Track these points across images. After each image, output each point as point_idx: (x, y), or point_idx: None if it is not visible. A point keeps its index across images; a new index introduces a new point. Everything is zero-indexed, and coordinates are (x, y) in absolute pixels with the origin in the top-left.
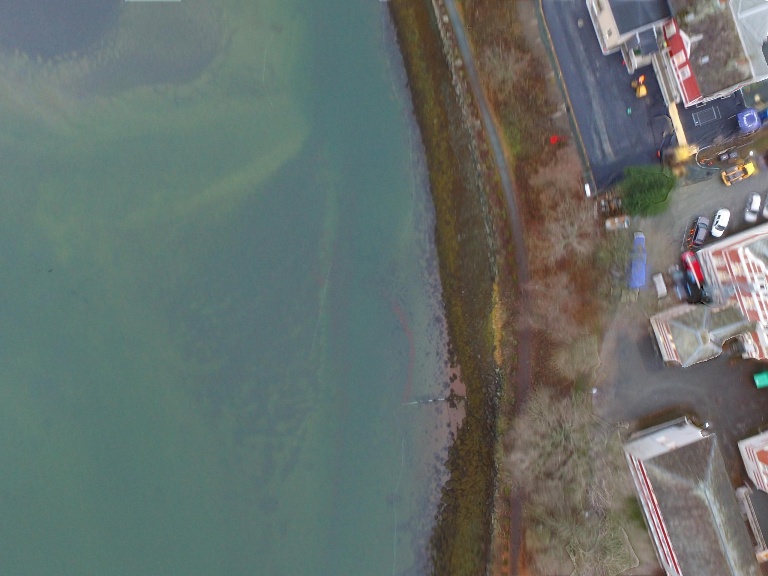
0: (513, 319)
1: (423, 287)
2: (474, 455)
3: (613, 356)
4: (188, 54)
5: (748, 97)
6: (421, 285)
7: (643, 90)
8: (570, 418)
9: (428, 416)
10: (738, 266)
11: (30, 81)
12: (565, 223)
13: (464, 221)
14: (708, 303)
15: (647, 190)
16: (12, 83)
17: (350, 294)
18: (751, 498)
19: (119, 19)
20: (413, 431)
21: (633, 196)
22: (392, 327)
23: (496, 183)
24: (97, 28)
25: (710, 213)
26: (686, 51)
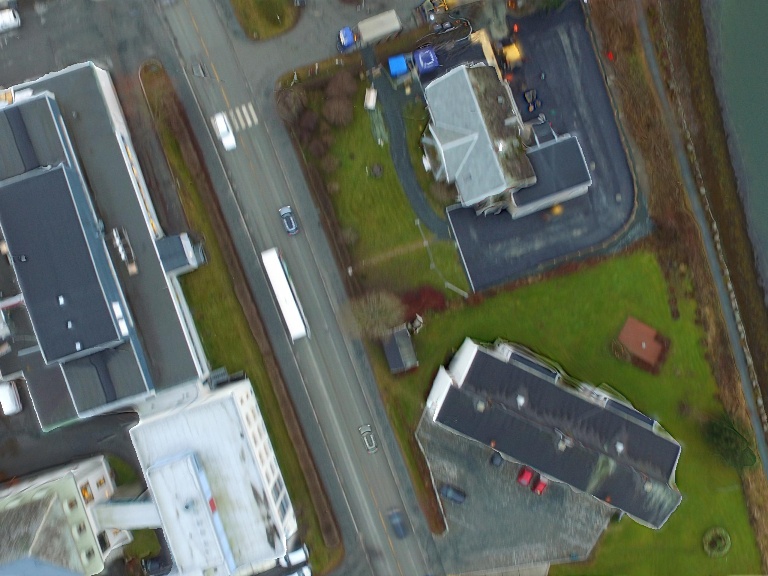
0: None
1: None
2: None
3: None
4: None
5: (418, 91)
6: None
7: (529, 98)
8: None
9: None
10: None
11: None
12: None
13: None
14: None
15: None
16: None
17: None
18: None
19: None
20: None
21: None
22: None
23: (655, 25)
24: None
25: None
26: None
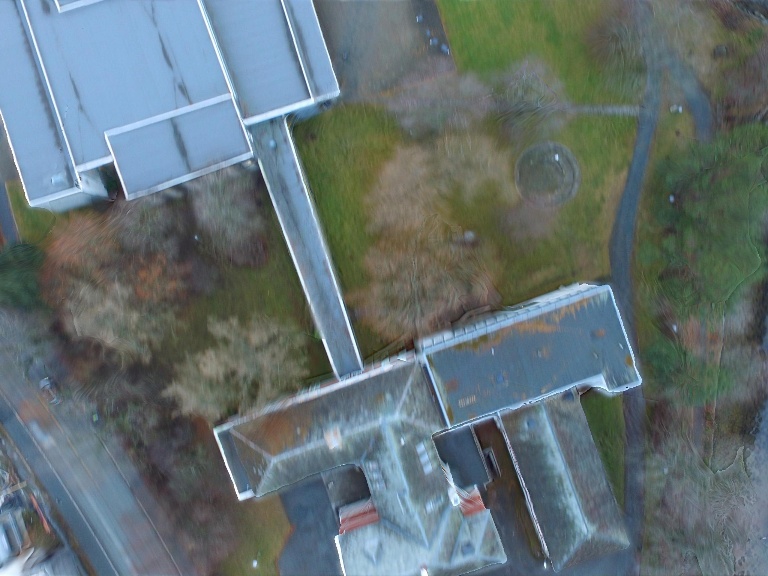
0: None
1: None
2: None
3: None
4: None
5: None
6: None
7: None
8: None
9: (767, 523)
10: None
11: None
12: None
13: None
14: None
15: None
16: None
17: None
18: (488, 479)
19: None
20: None
21: None
22: None
23: None
24: None
25: None
26: None
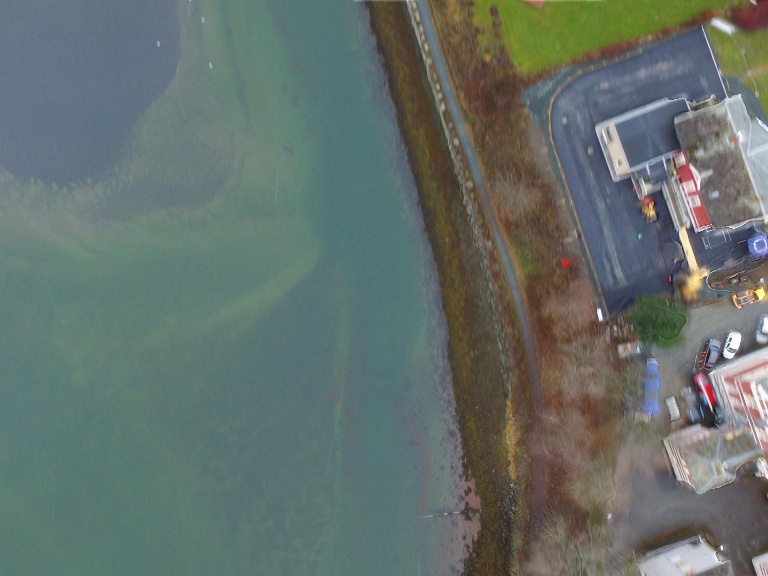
0: (527, 437)
1: (437, 402)
2: (490, 568)
3: (627, 476)
4: (201, 178)
5: (757, 220)
6: (435, 400)
7: (653, 215)
8: (587, 555)
9: (444, 529)
10: (751, 399)
11: (46, 208)
12: (577, 345)
13: (477, 338)
14: (721, 425)
15: (660, 327)
16: (28, 210)
17: (365, 410)
18: None
19: (133, 145)
20: (429, 544)
21: (645, 327)
22: (407, 442)
23: (508, 302)
24: (111, 154)
25: (721, 335)
26: (696, 183)
